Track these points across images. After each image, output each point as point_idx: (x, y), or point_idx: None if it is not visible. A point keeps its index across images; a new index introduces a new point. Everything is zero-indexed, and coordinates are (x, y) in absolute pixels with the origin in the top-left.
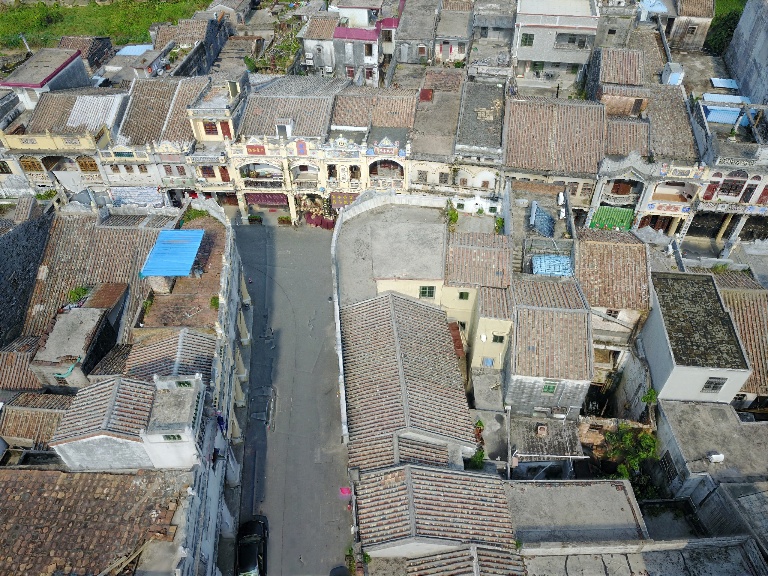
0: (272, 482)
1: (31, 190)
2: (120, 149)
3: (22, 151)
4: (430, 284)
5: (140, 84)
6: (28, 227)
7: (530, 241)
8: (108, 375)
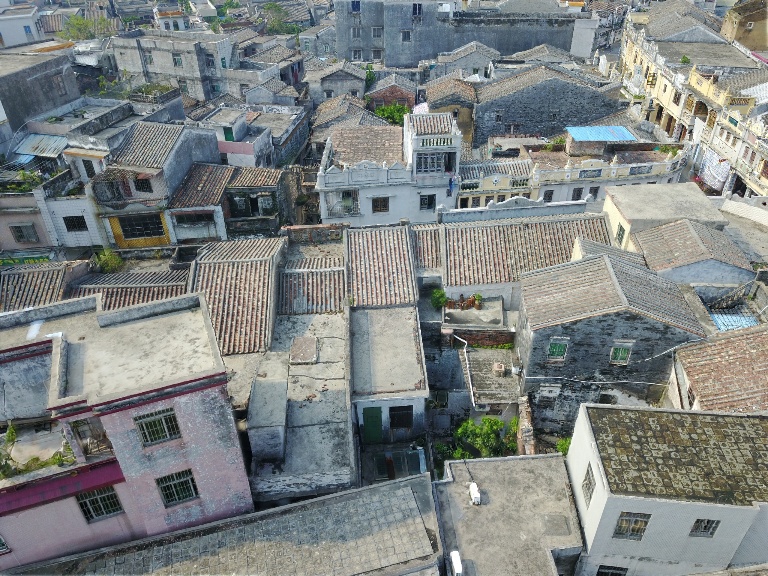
0: None
1: (638, 91)
2: (735, 115)
3: (691, 88)
4: (624, 225)
5: None
6: (597, 97)
7: (756, 285)
8: None
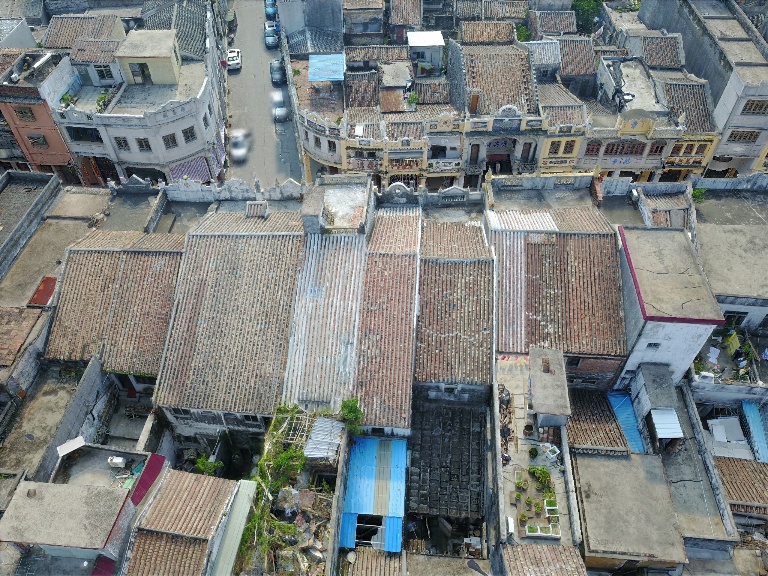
0: (272, 98)
1: None
2: (456, 191)
3: None
4: None
5: (483, 255)
6: None
7: None
8: (365, 73)
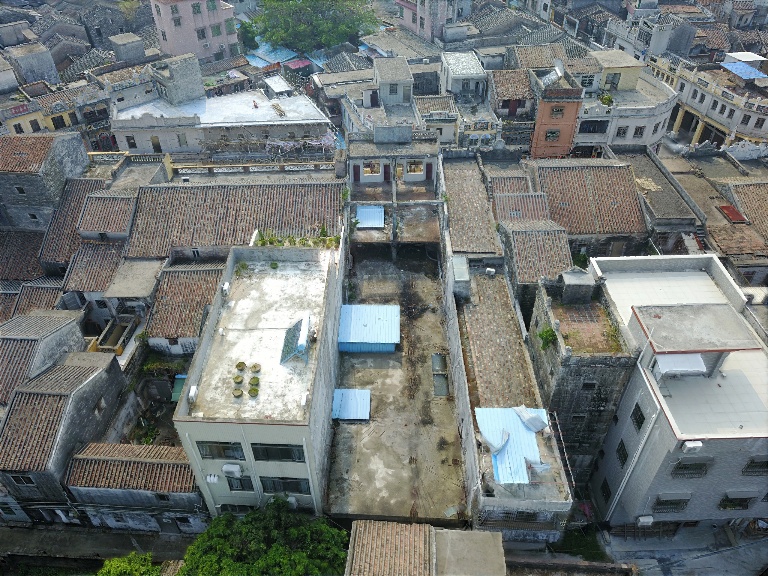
0: None
1: None
2: None
3: None
4: None
5: None
6: None
7: None
8: None
